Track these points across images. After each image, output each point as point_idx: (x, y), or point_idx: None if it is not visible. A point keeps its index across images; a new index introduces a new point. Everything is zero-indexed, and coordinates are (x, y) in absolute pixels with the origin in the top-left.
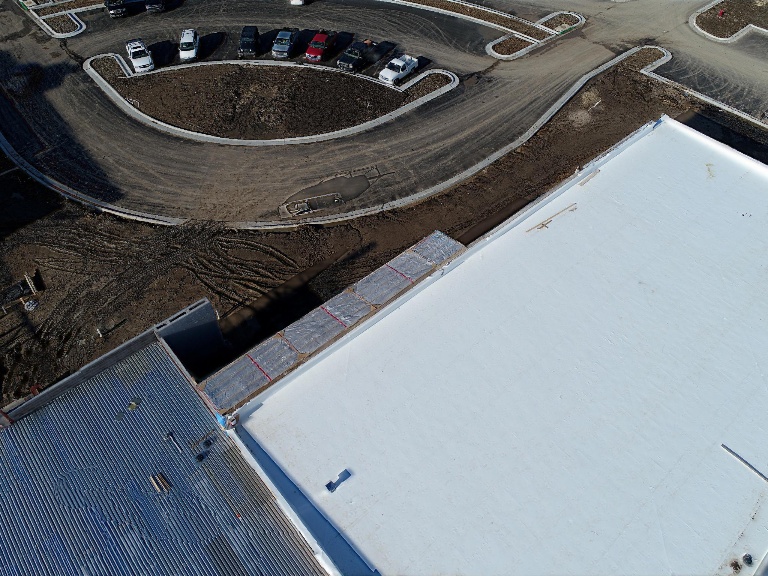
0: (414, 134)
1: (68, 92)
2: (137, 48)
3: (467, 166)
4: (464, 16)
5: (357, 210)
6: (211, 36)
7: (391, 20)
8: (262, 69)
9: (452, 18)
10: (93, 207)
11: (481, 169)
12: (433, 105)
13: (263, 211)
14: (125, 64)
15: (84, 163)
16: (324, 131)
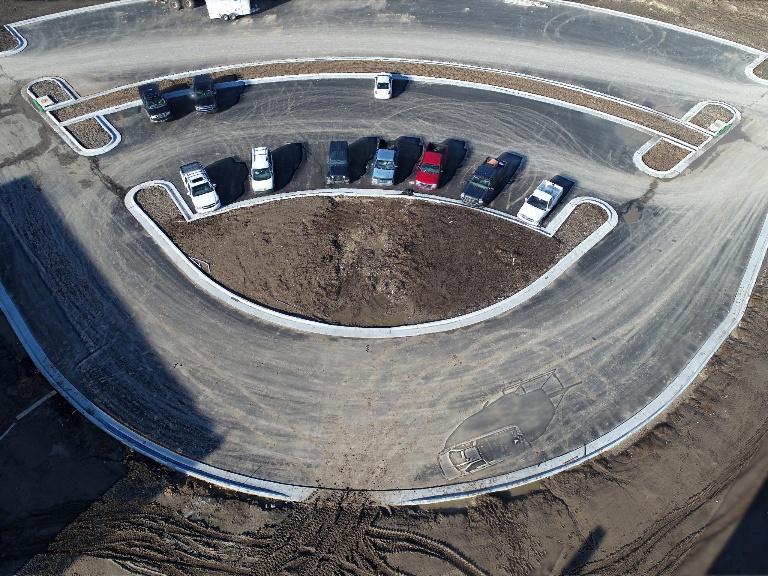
0: (587, 310)
1: (110, 247)
2: (198, 181)
3: (676, 367)
4: (591, 111)
5: (551, 460)
6: (284, 150)
7: (504, 119)
8: (361, 203)
9: (577, 114)
10: (172, 468)
11: (698, 373)
12: (597, 257)
13: (418, 466)
14: (180, 198)
15: (148, 379)
16: (467, 309)
